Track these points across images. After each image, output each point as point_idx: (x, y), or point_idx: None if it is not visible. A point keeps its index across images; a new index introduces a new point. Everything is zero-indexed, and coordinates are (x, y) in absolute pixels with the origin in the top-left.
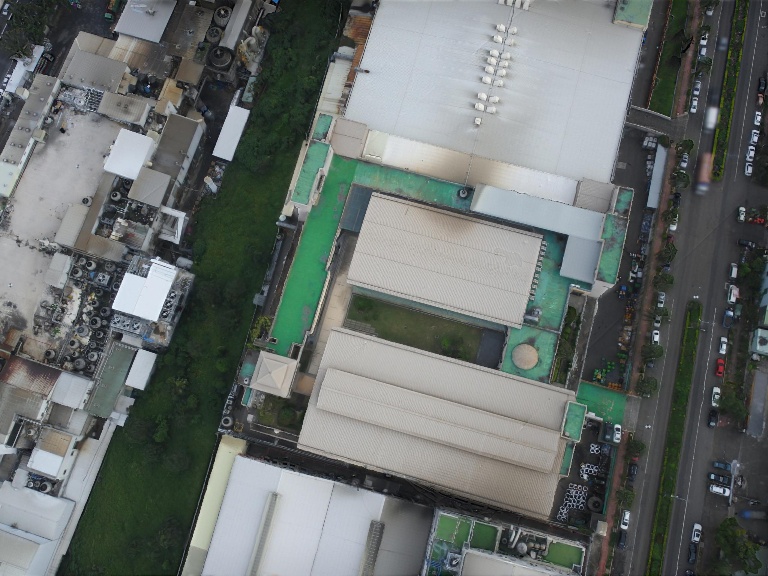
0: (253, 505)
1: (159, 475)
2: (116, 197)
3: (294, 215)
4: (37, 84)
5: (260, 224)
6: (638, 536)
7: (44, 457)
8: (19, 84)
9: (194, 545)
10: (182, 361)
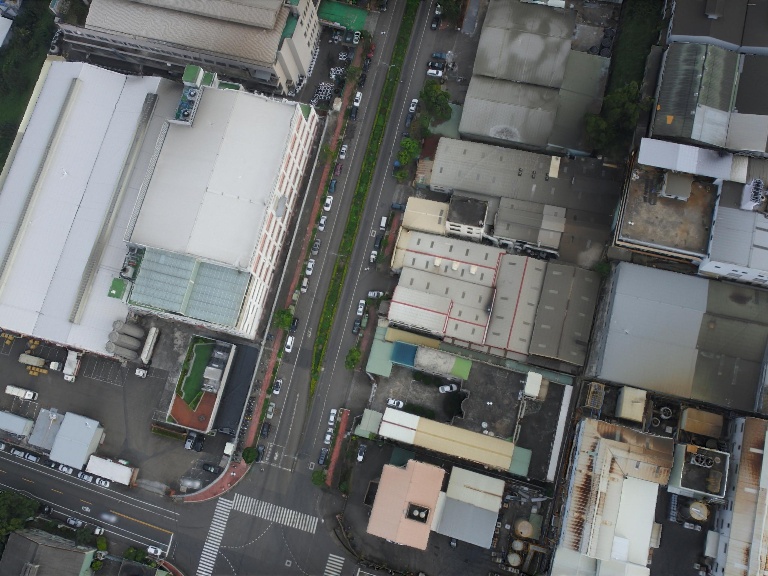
0: (61, 91)
1: (6, 101)
2: None
3: None
4: None
5: None
6: (367, 111)
7: None
8: None
9: (20, 131)
10: (27, 17)
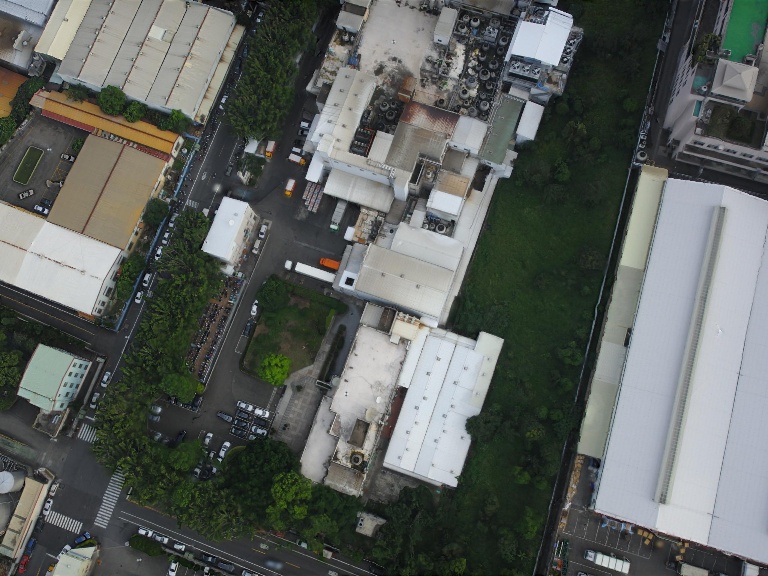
0: (695, 220)
1: (562, 214)
2: None
3: None
4: None
5: None
6: None
7: (443, 197)
8: None
9: (625, 264)
10: (580, 107)
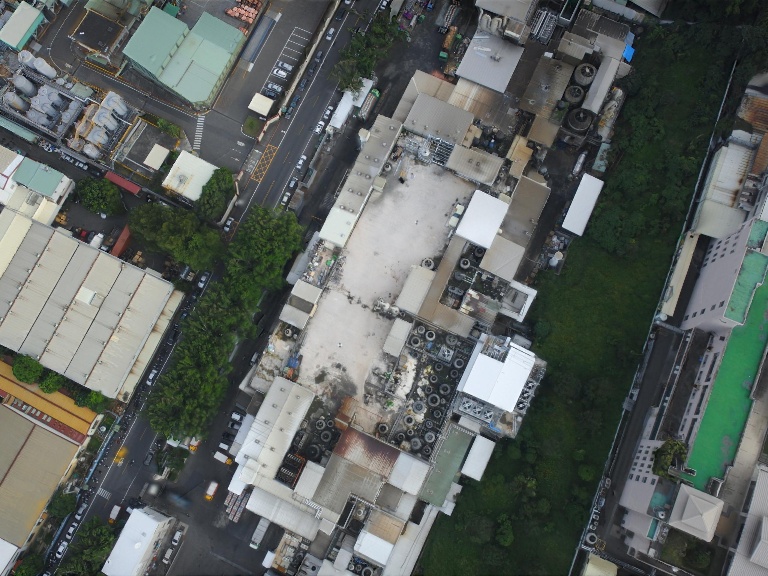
0: None
1: None
2: (467, 265)
3: (675, 315)
4: (379, 126)
5: (624, 315)
6: None
7: (373, 541)
8: (344, 119)
9: None
10: (533, 458)
